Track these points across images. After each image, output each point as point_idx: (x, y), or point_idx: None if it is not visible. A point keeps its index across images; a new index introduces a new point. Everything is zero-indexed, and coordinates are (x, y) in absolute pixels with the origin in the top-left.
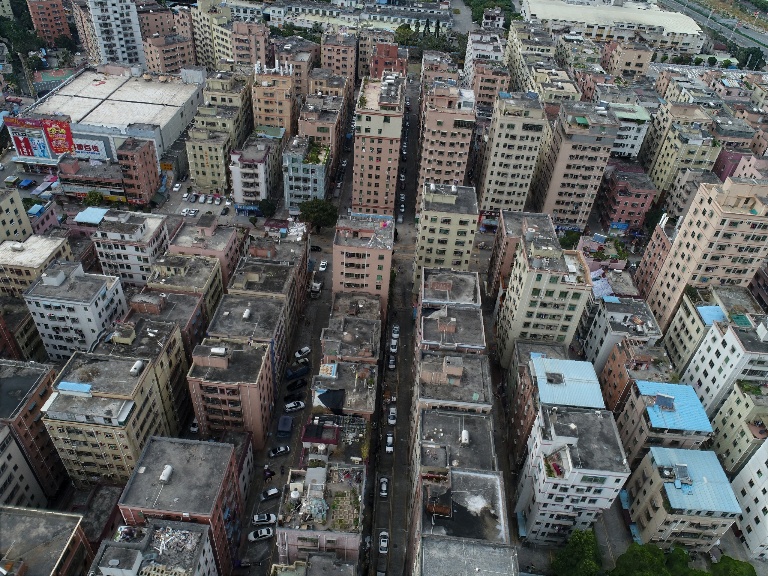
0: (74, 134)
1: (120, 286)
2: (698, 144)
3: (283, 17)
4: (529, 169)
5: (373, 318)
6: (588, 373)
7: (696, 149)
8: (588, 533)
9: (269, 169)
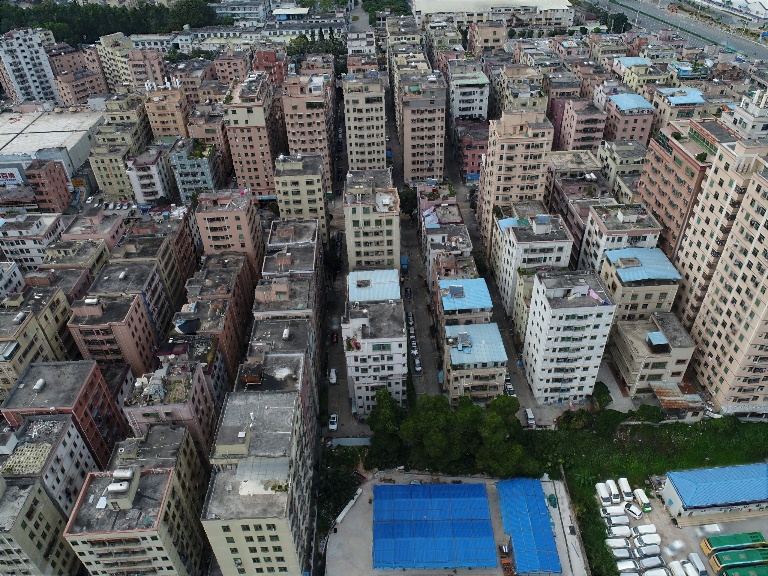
0: None
1: (18, 270)
2: (527, 97)
3: (190, 44)
4: (381, 137)
5: (238, 270)
6: (392, 277)
7: (527, 101)
8: (383, 390)
9: (164, 170)
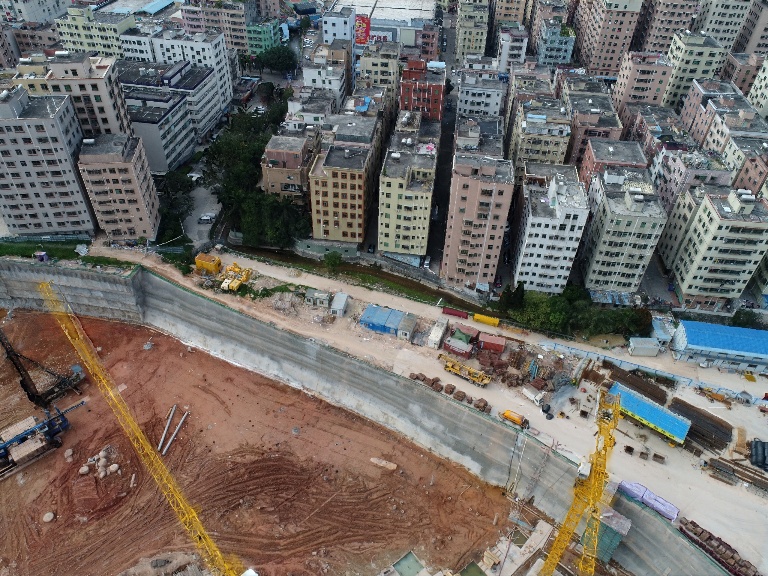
0: (372, 27)
1: None
2: None
3: None
4: (734, 33)
5: None
6: None
7: None
8: None
9: None
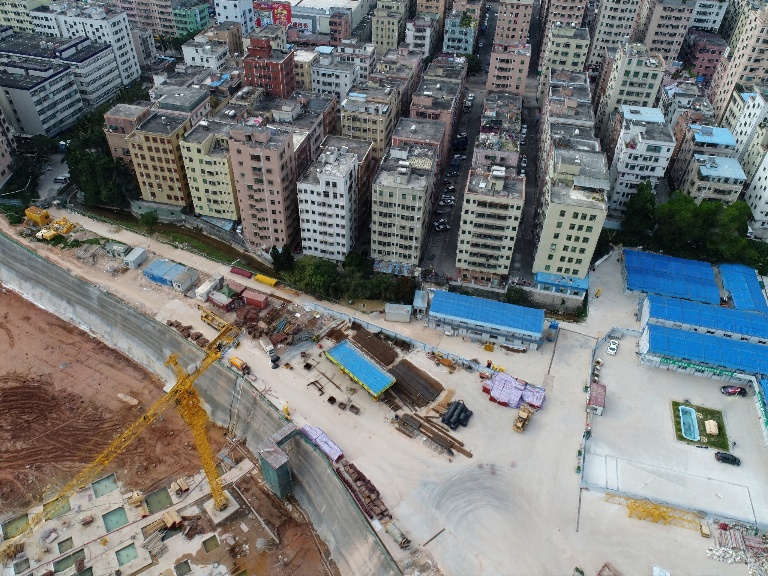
0: (293, 14)
1: (358, 73)
2: None
3: None
4: (628, 28)
5: None
6: (657, 112)
7: None
8: (648, 180)
9: (431, 36)
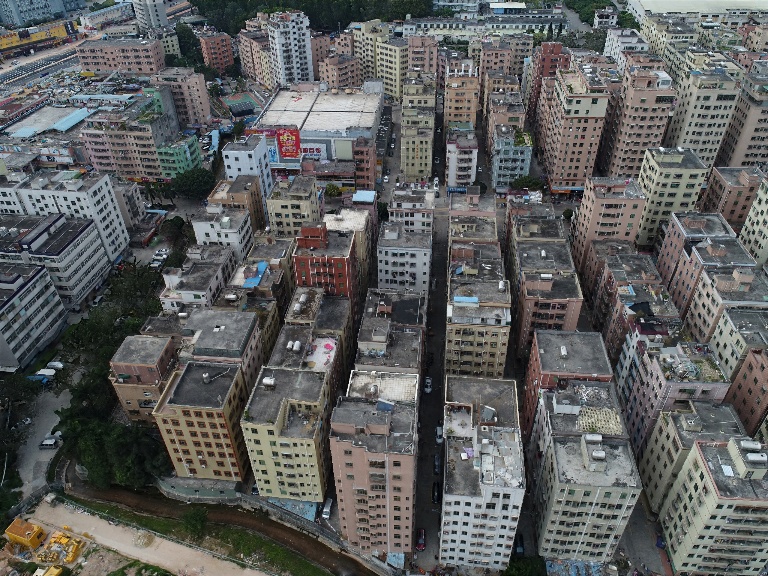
0: (302, 140)
1: None
2: None
3: (415, 33)
4: (719, 135)
5: None
6: None
7: None
8: None
9: None
